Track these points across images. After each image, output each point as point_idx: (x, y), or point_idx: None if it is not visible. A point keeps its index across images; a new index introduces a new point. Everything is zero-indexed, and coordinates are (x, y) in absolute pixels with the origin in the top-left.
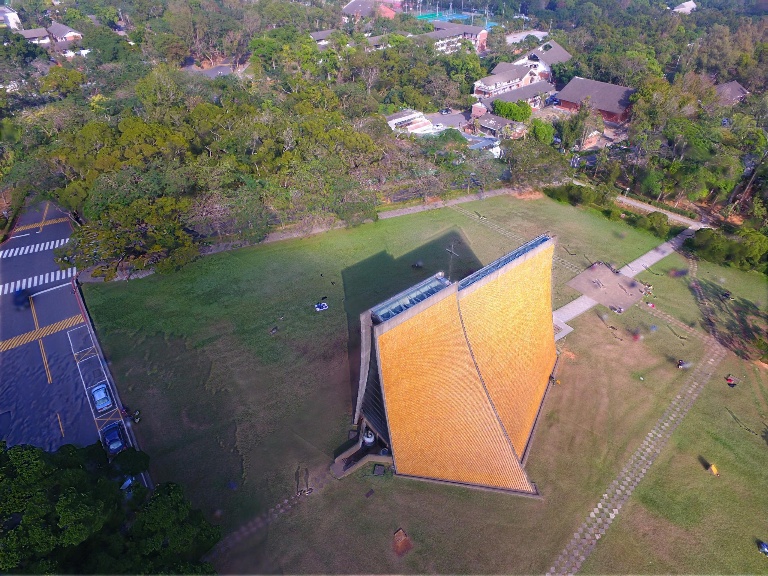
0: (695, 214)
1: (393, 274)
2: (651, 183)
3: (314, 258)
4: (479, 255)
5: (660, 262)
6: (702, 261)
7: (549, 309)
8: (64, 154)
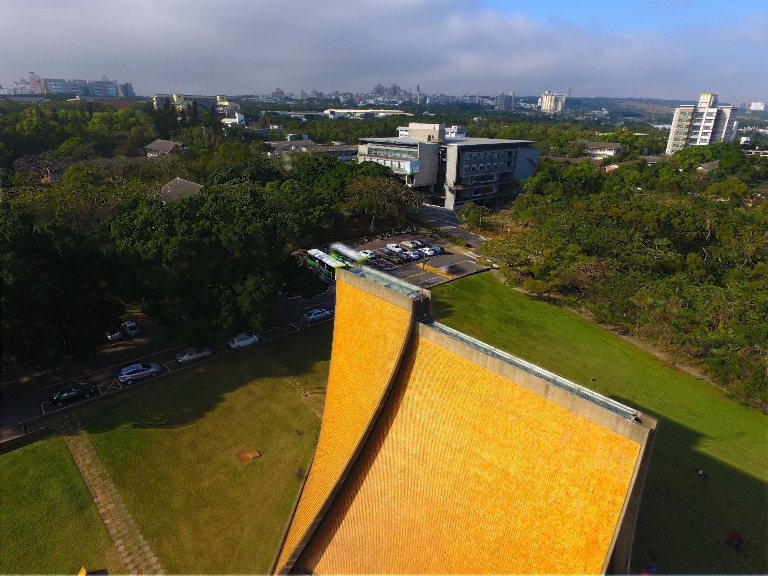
0: None
1: (655, 446)
2: None
3: (624, 372)
4: None
5: None
6: None
7: None
8: None
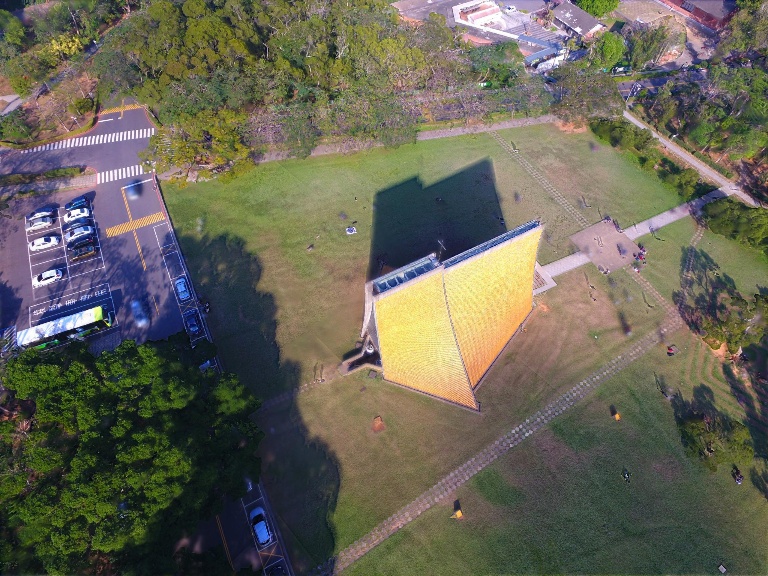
0: (732, 174)
1: (417, 206)
2: (698, 135)
3: (352, 179)
4: (500, 195)
5: (668, 226)
6: (710, 230)
7: (531, 275)
8: (138, 48)
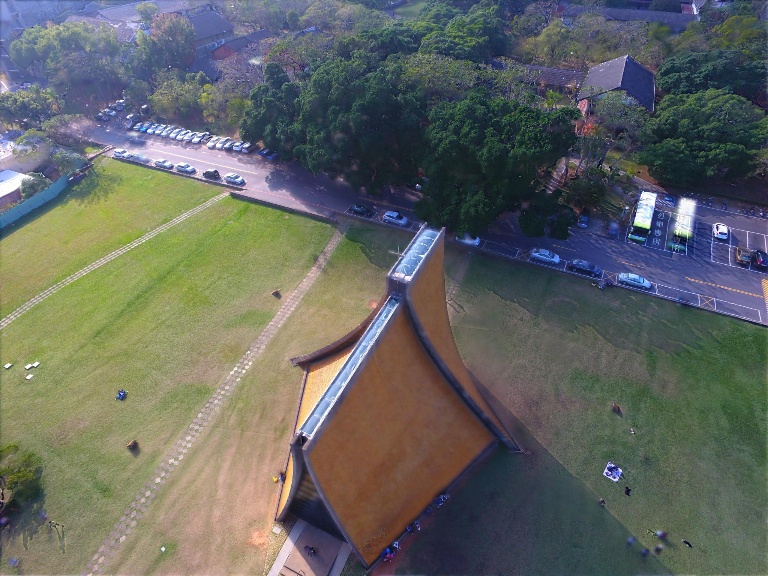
0: None
1: None
2: None
3: None
4: None
5: None
6: None
7: None
8: None
